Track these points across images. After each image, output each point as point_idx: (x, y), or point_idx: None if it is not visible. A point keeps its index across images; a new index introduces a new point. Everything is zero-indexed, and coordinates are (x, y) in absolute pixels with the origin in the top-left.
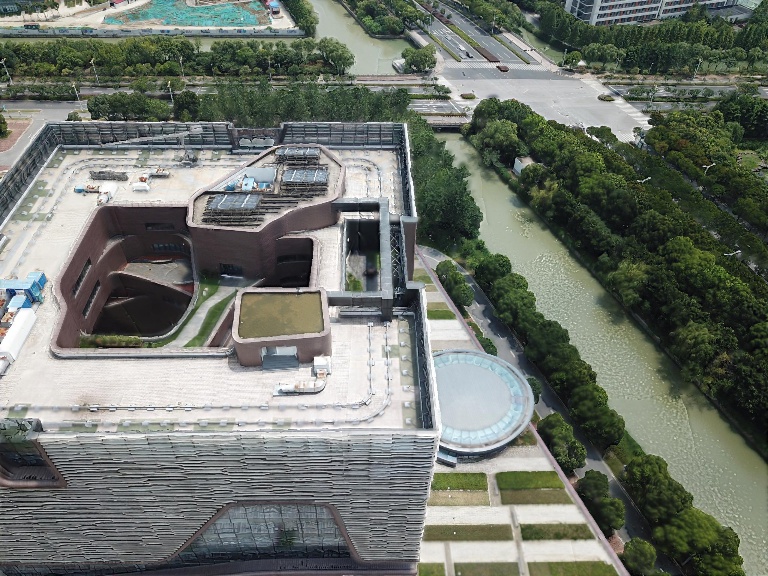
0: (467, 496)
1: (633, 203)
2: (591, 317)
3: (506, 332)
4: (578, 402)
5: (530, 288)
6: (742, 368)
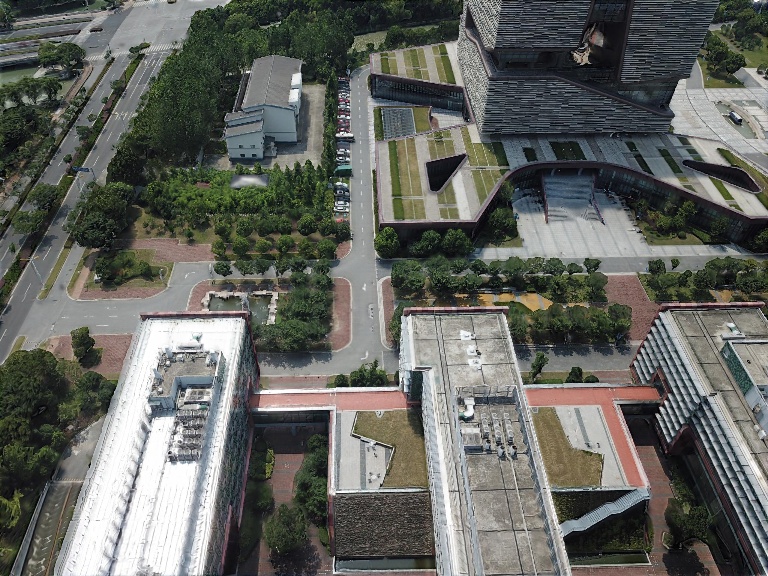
0: None
1: None
2: None
3: None
4: None
5: None
6: None
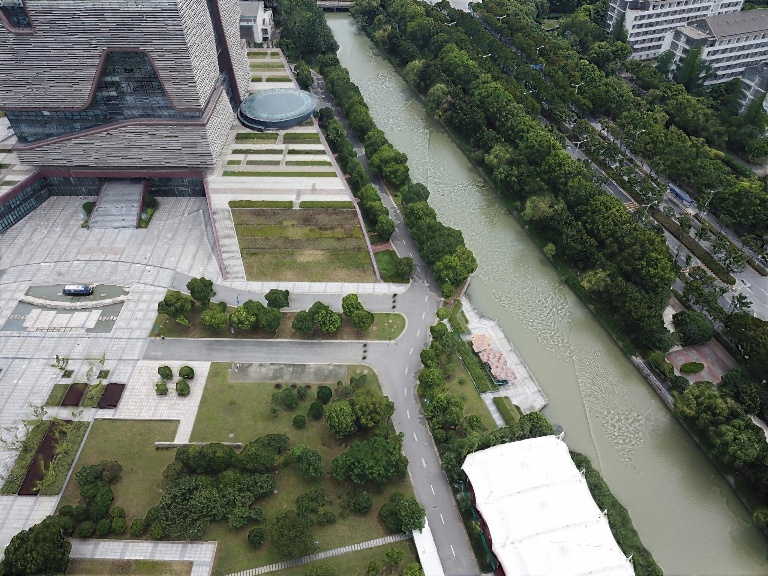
0: (265, 141)
1: (430, 30)
2: (392, 97)
3: (332, 101)
4: (350, 116)
5: (362, 87)
6: (456, 102)
